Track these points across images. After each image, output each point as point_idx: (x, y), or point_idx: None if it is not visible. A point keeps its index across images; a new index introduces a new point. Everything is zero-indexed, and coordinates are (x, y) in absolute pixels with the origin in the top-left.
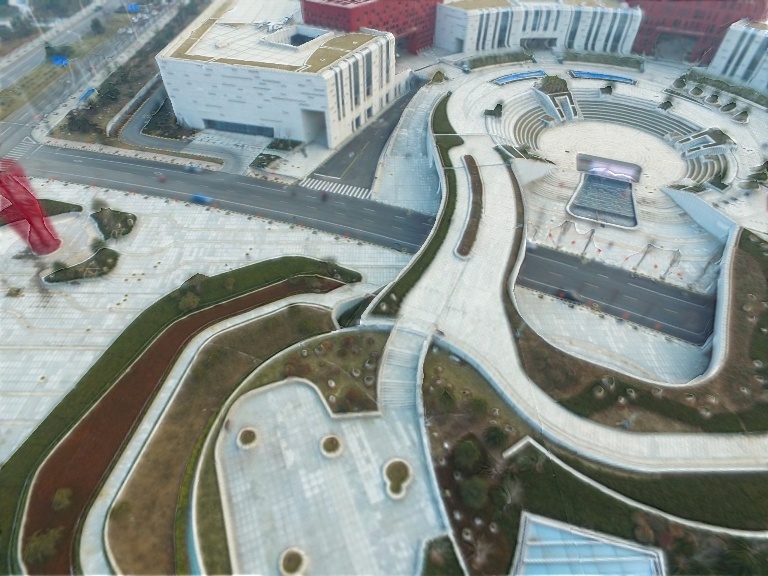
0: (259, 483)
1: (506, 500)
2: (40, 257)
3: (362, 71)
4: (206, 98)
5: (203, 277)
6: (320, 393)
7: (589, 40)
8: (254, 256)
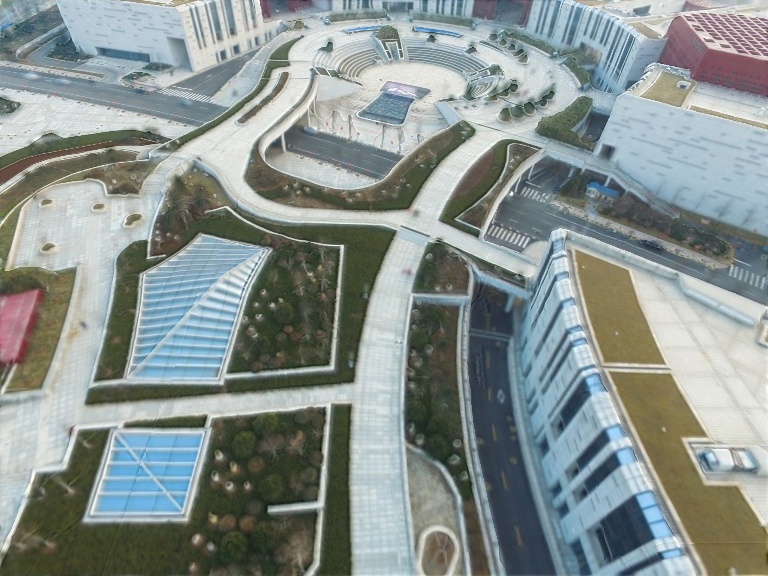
0: (45, 221)
1: (184, 220)
2: None
3: (221, 12)
4: (95, 28)
5: (55, 135)
6: (105, 186)
7: (439, 5)
8: (102, 129)
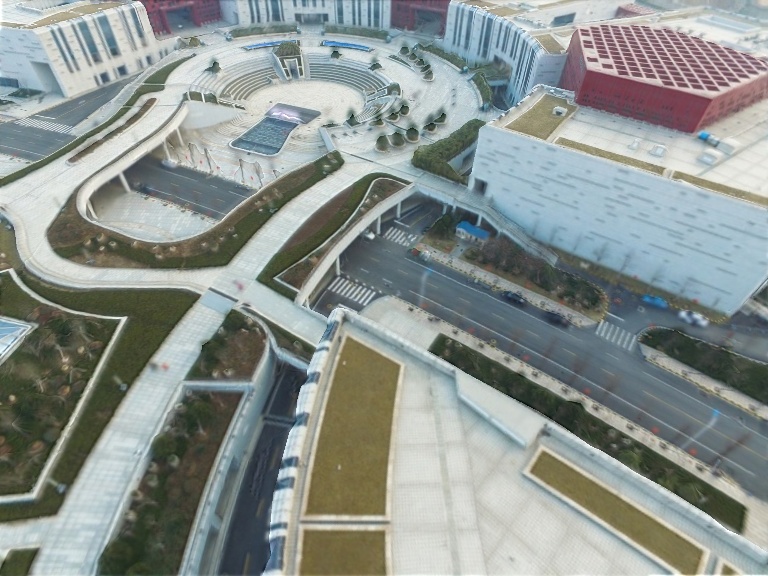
0: None
1: None
2: None
3: (96, 32)
4: None
5: None
6: None
7: (355, 16)
8: None
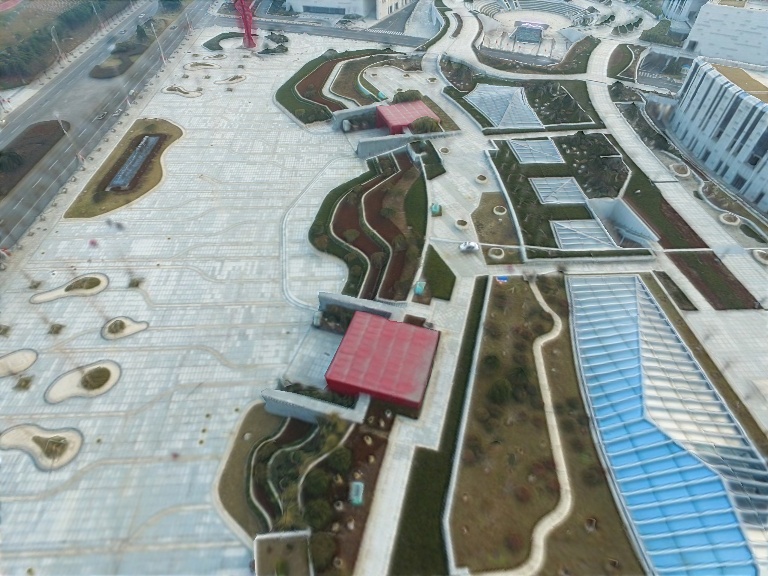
0: (382, 82)
1: (471, 74)
2: (249, 48)
3: None
4: None
5: None
6: (399, 68)
7: None
8: (352, 50)
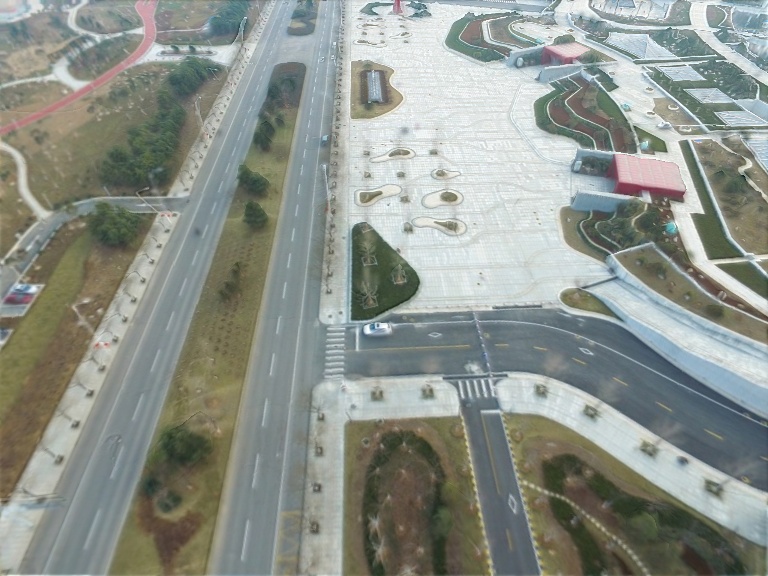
0: (531, 33)
1: None
2: None
3: None
4: None
5: None
6: None
7: None
8: None
